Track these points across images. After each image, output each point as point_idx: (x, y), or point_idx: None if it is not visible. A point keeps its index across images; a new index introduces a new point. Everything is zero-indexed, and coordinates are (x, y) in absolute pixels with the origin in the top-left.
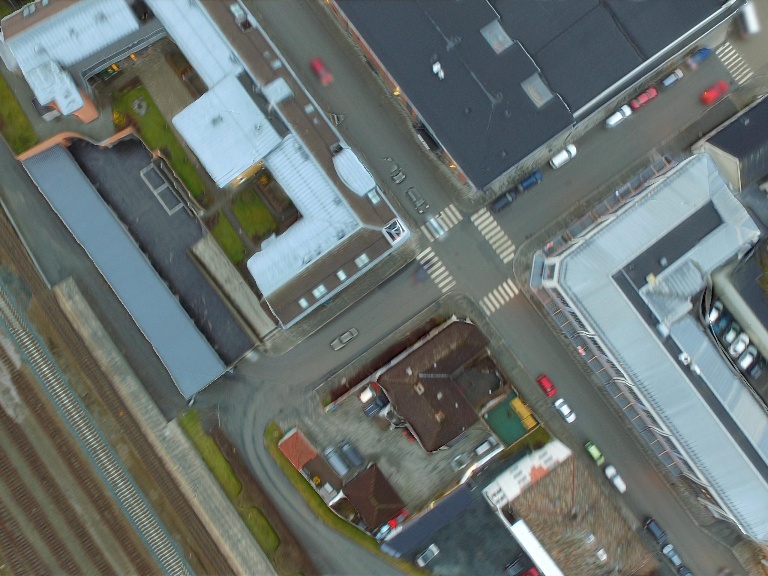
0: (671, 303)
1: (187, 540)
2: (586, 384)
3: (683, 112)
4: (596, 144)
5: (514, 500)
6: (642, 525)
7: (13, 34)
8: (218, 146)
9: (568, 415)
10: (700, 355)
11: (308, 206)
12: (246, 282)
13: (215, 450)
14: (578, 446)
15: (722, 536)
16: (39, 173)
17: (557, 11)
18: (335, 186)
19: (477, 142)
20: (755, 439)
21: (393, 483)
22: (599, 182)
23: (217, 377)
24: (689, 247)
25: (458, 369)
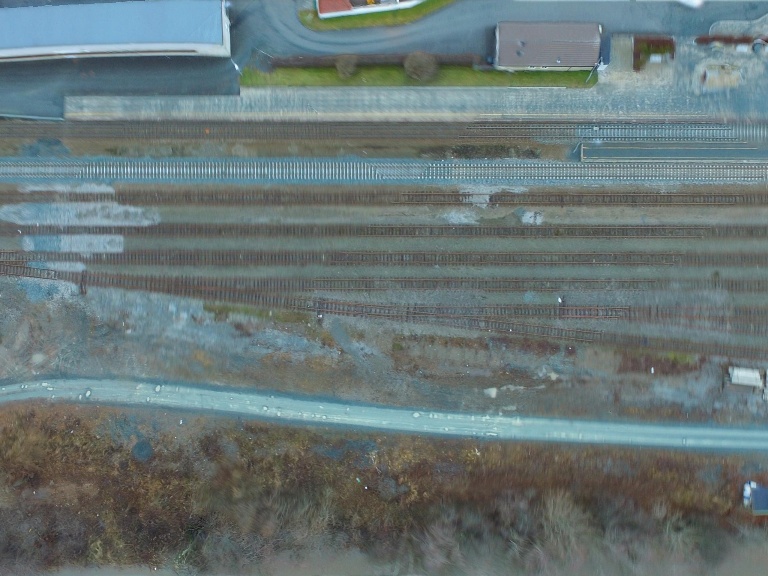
0: None
1: (350, 146)
2: None
3: None
4: None
5: None
6: None
7: None
8: None
9: None
10: None
11: None
12: None
13: (290, 74)
14: None
15: None
16: None
17: None
18: None
19: None
20: None
21: None
22: None
23: (221, 9)
24: None
25: None
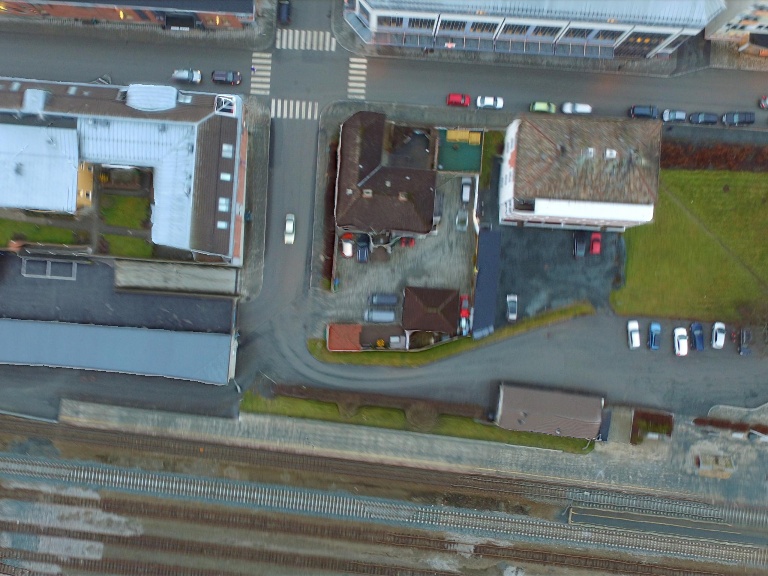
0: None
1: (342, 482)
2: (484, 69)
3: None
4: None
5: (515, 191)
6: (628, 117)
7: None
8: (40, 186)
9: (495, 103)
10: None
11: (148, 156)
12: (172, 260)
13: (291, 402)
14: (525, 115)
15: (694, 65)
16: None
17: None
18: (148, 119)
19: None
20: None
21: (433, 286)
22: None
23: (230, 348)
24: None
25: (382, 155)
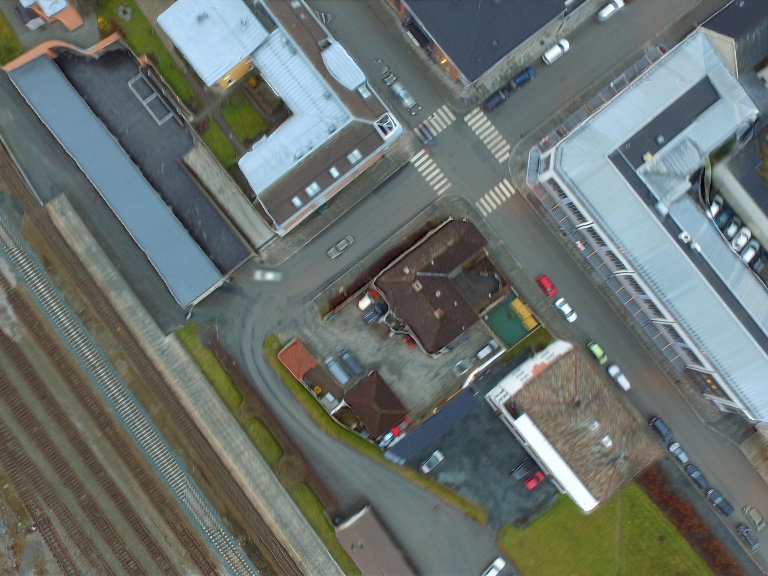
0: (669, 183)
1: (190, 454)
2: (586, 283)
3: (677, 2)
4: (589, 38)
5: (516, 393)
6: (647, 422)
7: None
8: (204, 44)
9: (569, 314)
10: (700, 235)
11: (298, 102)
12: (238, 186)
13: (214, 363)
14: (580, 345)
15: (729, 433)
16: (26, 84)
17: None
18: (324, 79)
19: (467, 31)
20: (759, 318)
21: (395, 390)
22: (593, 77)
23: (213, 285)
24: (686, 124)
25: (456, 268)
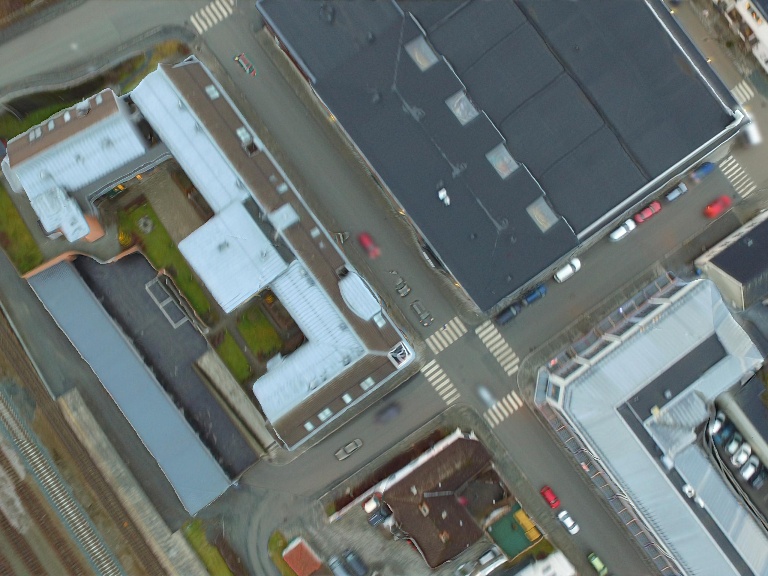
0: (675, 434)
1: None
2: (589, 495)
3: (686, 226)
4: (600, 257)
5: None
6: None
7: (19, 161)
8: (224, 271)
9: (571, 527)
10: (704, 484)
11: (314, 330)
12: (251, 401)
13: (219, 560)
14: (581, 558)
15: None
16: (44, 290)
17: (562, 132)
18: (341, 312)
19: (482, 266)
20: (758, 569)
21: None
22: (603, 295)
23: (222, 493)
24: (693, 379)
25: (462, 485)
